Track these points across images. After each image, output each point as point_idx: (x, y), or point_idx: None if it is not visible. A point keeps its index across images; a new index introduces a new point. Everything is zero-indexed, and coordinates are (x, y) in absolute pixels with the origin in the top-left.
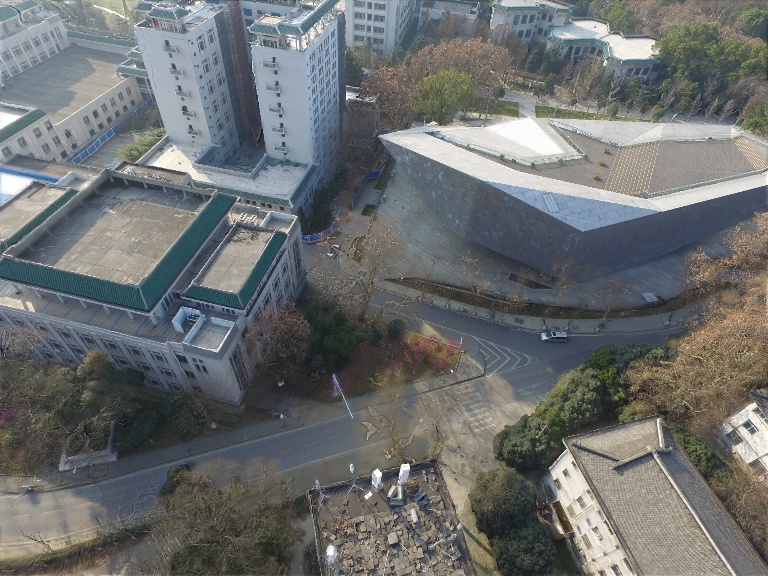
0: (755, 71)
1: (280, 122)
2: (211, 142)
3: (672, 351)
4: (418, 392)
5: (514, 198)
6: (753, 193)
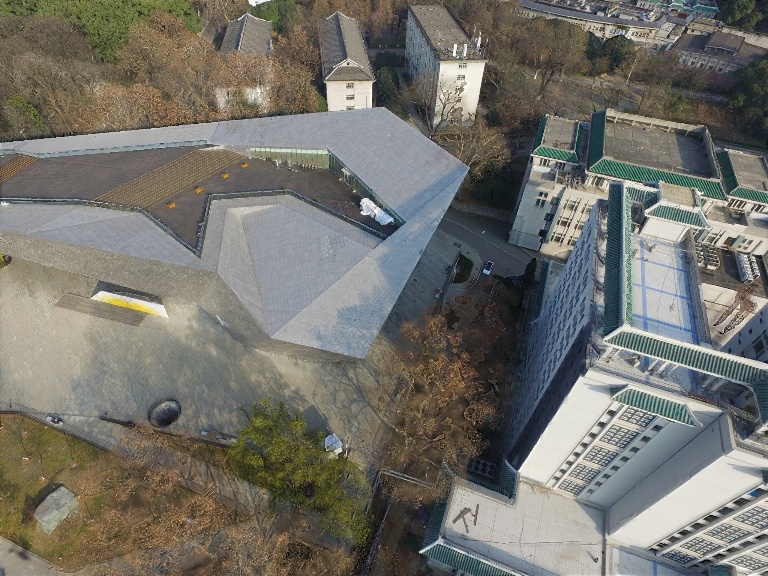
0: None
1: None
2: None
3: None
4: None
5: None
6: None
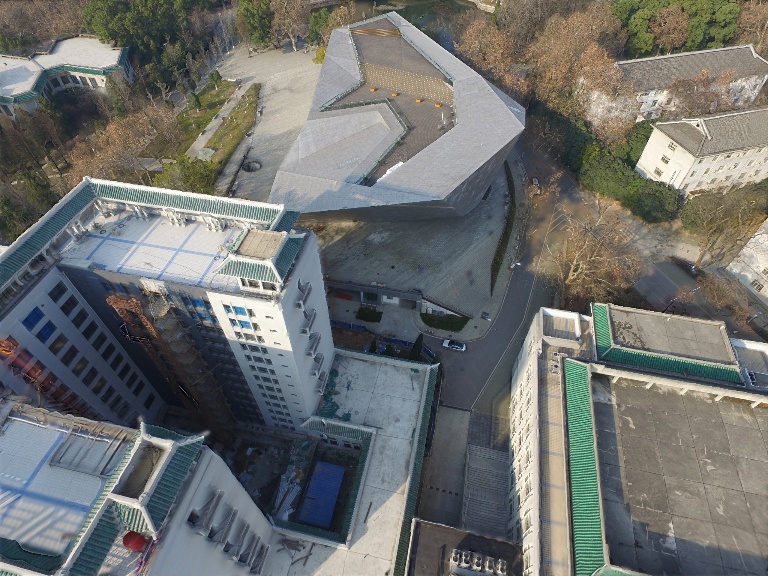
0: (187, 8)
1: None
2: (271, 527)
3: (573, 120)
4: None
5: None
6: None
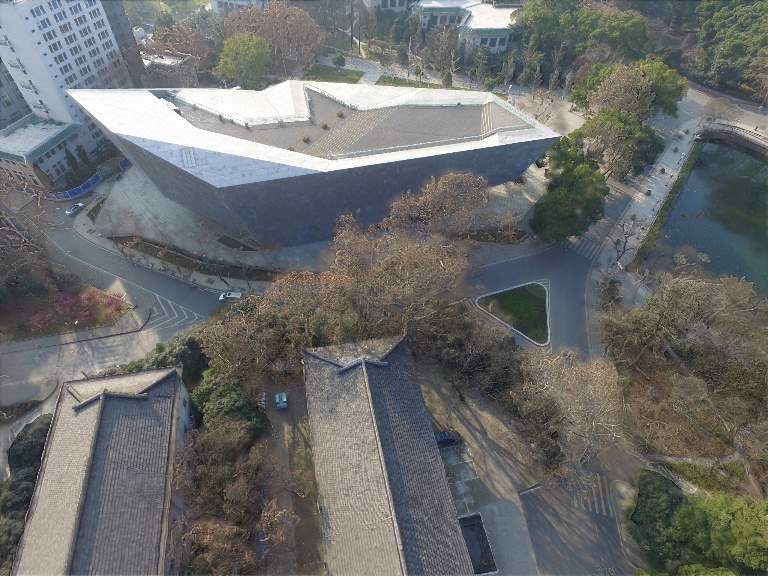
0: (602, 42)
1: (28, 79)
2: None
3: None
4: (60, 343)
5: (147, 151)
6: (457, 158)
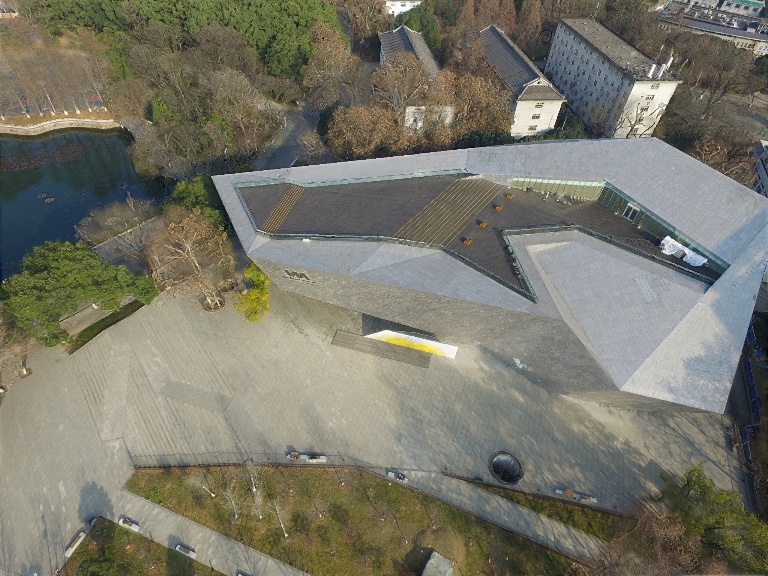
0: None
1: None
2: None
3: None
4: None
5: None
6: None
